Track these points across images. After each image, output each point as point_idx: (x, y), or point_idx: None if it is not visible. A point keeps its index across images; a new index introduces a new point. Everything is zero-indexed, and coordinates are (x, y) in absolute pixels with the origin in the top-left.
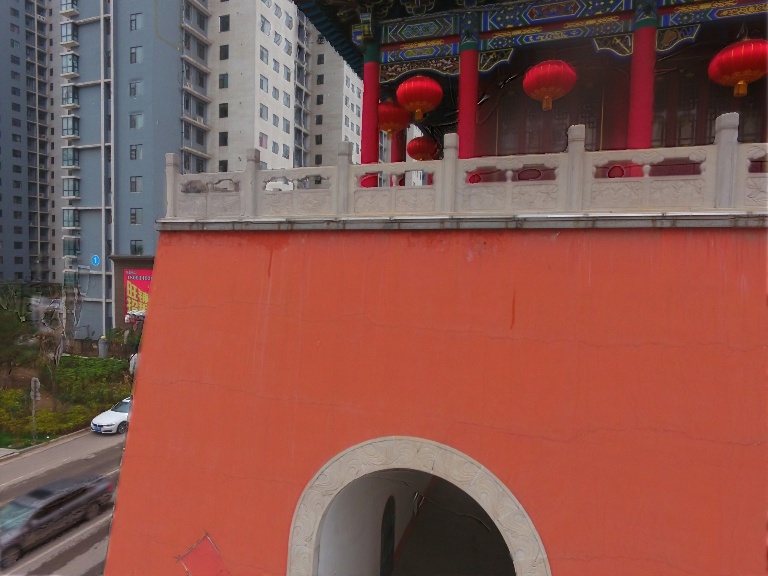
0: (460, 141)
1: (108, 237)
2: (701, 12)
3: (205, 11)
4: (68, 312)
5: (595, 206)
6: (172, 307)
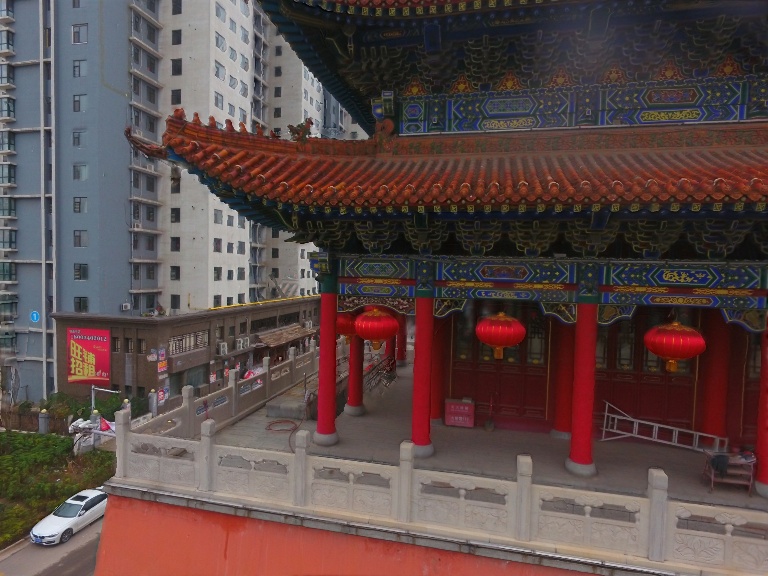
0: (416, 383)
1: (49, 293)
2: (637, 295)
3: (155, 54)
4: (4, 393)
5: (542, 536)
6: (122, 575)
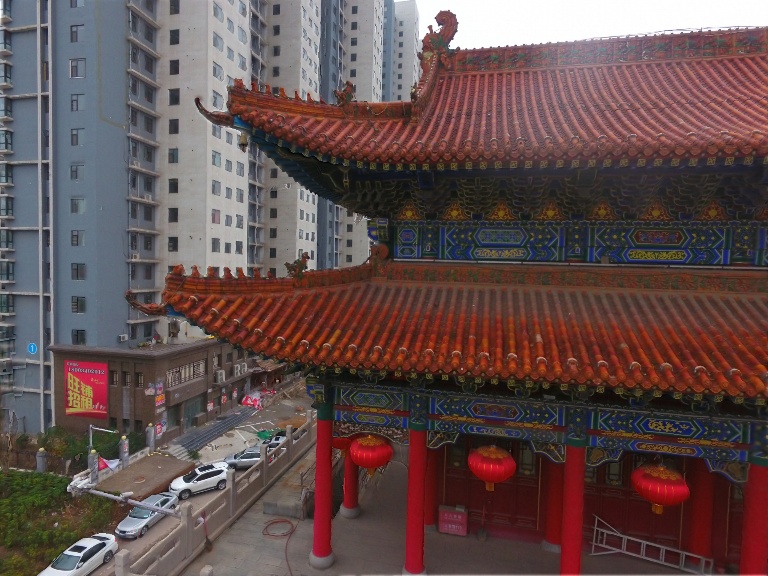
0: (410, 513)
1: (46, 325)
2: (624, 441)
3: (153, 84)
4: (2, 436)
5: None
6: None
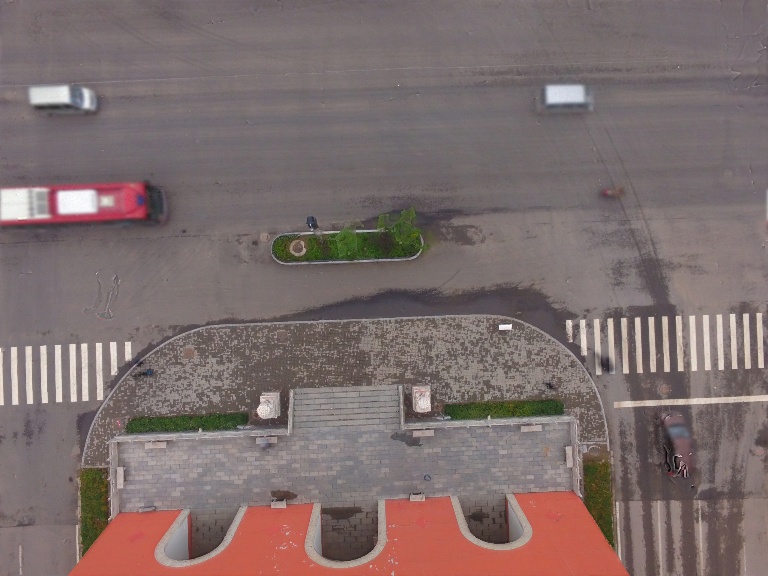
0: None
1: None
2: None
3: None
4: None
5: None
6: (613, 569)
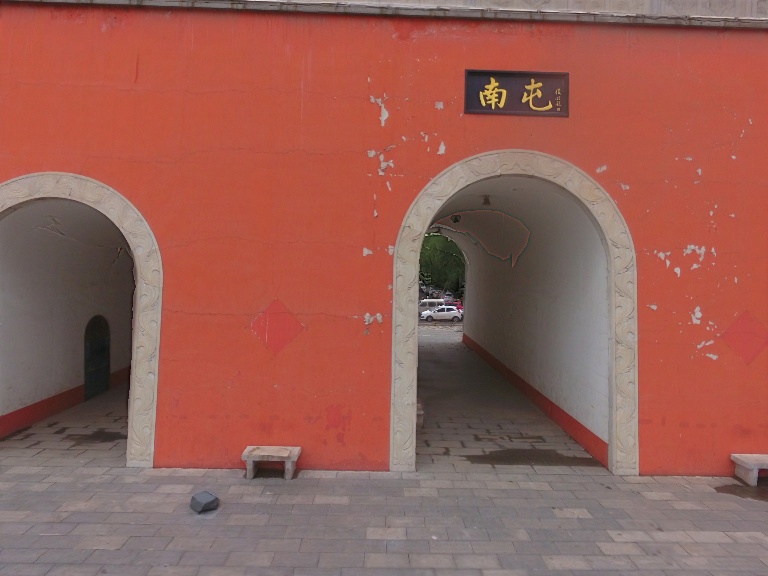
0: None
1: None
2: None
3: None
4: None
5: None
6: None
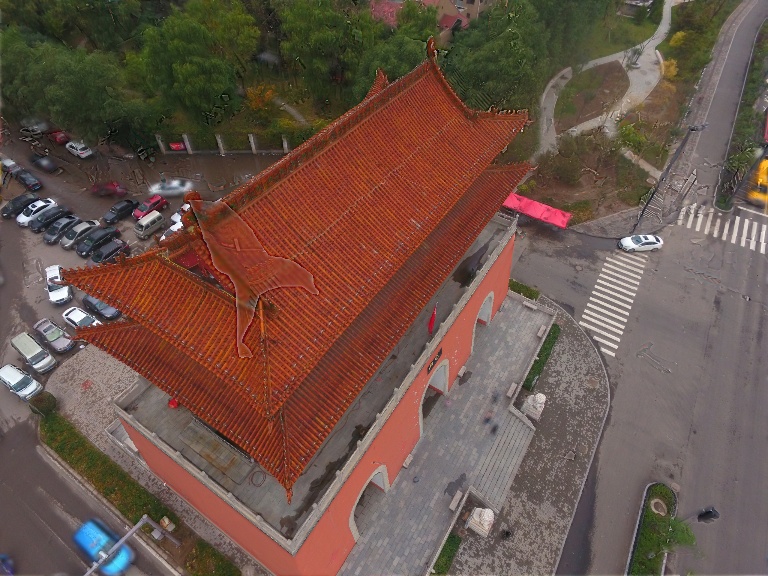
0: None
1: None
2: None
3: None
4: None
5: None
6: None
